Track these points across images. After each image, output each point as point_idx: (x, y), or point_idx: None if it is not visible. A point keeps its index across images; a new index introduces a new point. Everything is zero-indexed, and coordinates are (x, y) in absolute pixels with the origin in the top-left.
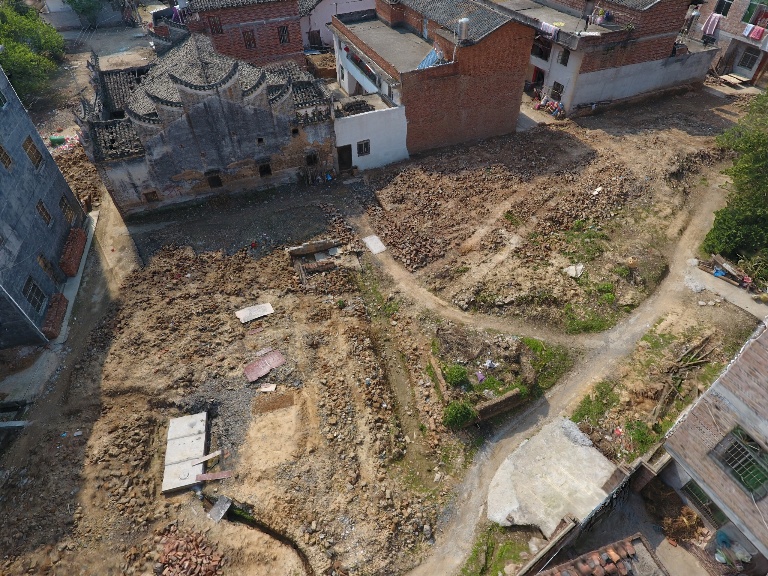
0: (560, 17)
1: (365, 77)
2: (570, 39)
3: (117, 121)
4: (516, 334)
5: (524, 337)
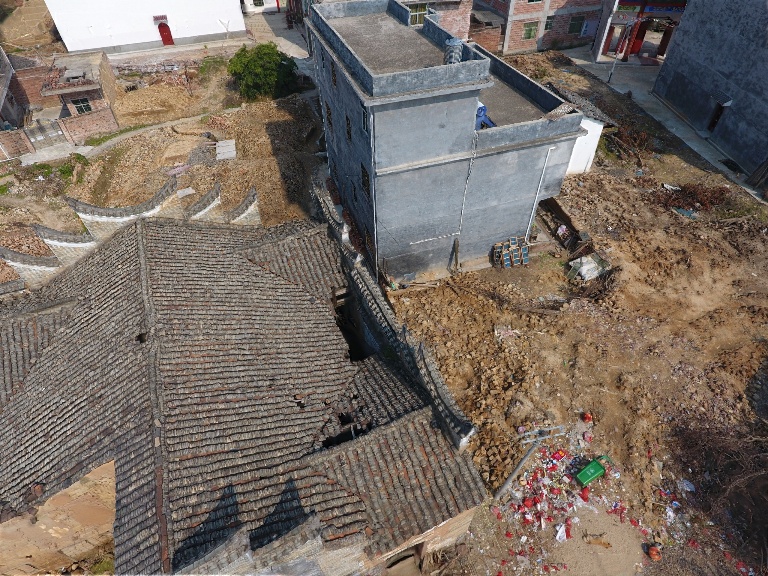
0: None
1: None
2: None
3: (296, 233)
4: (7, 196)
5: (4, 194)
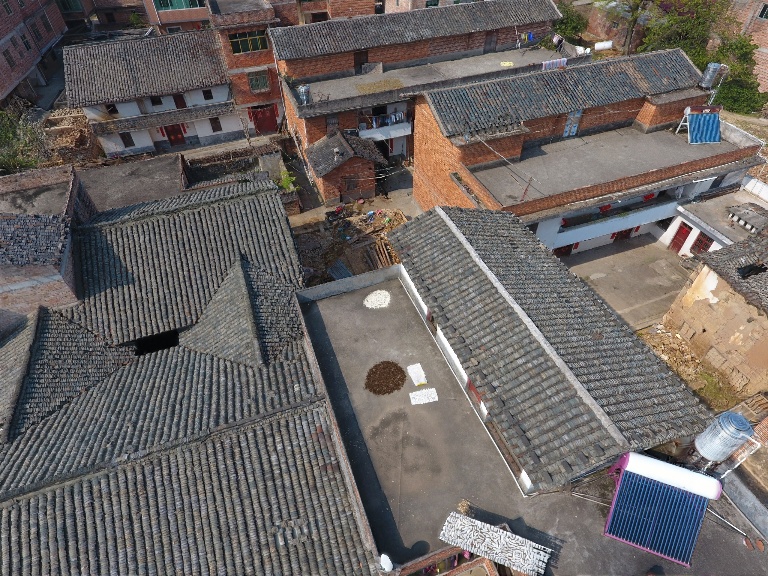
0: (479, 61)
1: (637, 213)
2: (583, 60)
3: None
4: None
5: None
